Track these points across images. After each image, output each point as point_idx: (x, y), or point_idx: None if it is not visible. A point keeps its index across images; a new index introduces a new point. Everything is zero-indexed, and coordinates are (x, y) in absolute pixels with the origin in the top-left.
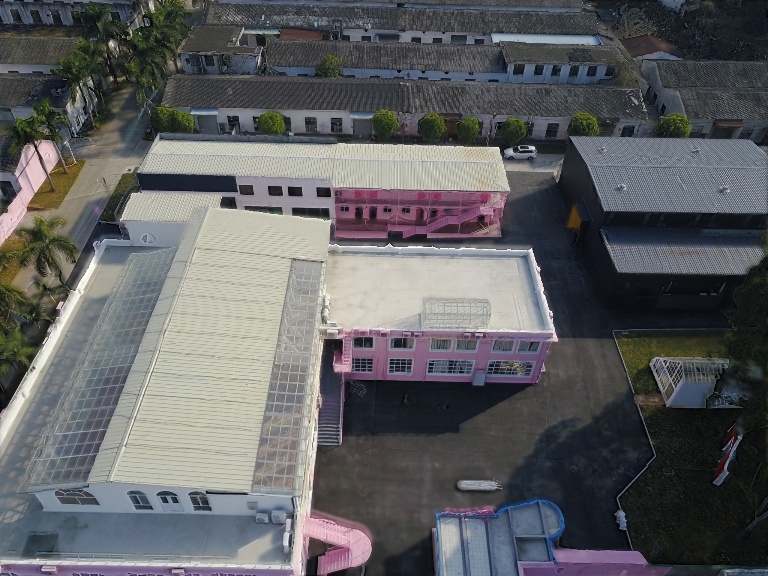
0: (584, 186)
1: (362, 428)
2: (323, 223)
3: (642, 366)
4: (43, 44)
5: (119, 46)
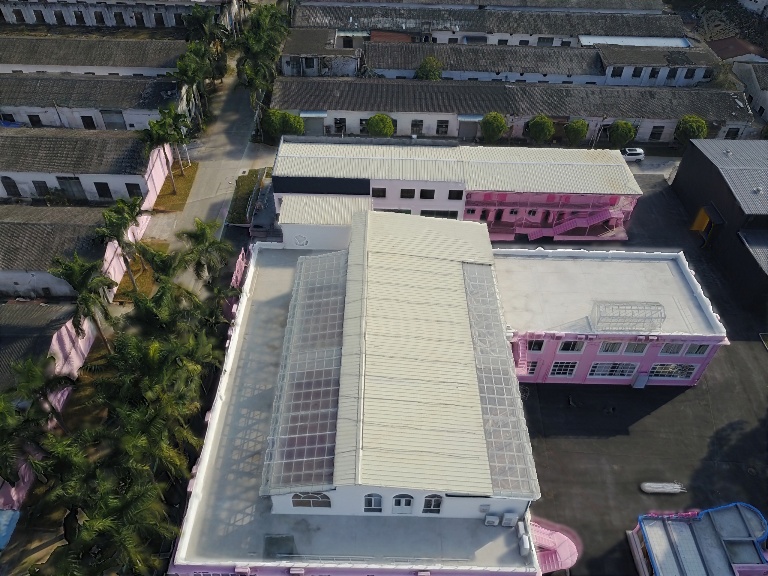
0: (712, 189)
1: (533, 430)
2: (480, 226)
3: None
4: (142, 46)
5: (217, 48)
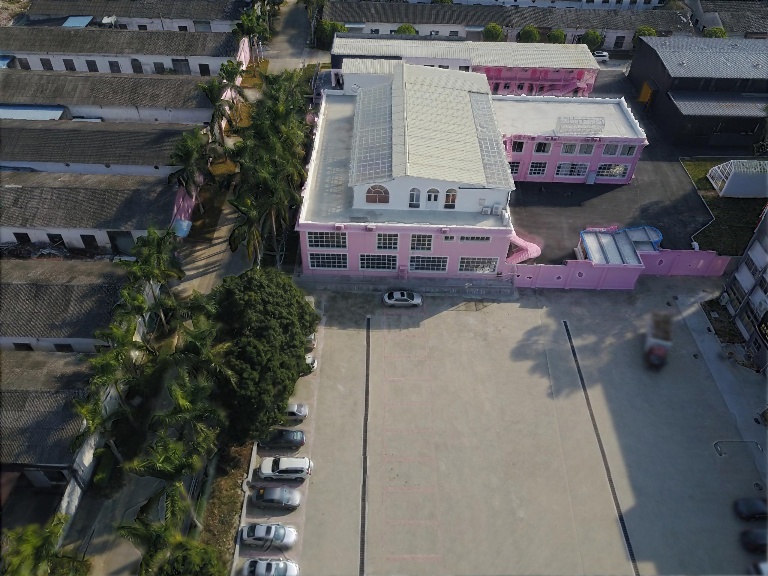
0: (653, 68)
1: (516, 203)
2: (481, 75)
3: (701, 176)
4: None
5: None
